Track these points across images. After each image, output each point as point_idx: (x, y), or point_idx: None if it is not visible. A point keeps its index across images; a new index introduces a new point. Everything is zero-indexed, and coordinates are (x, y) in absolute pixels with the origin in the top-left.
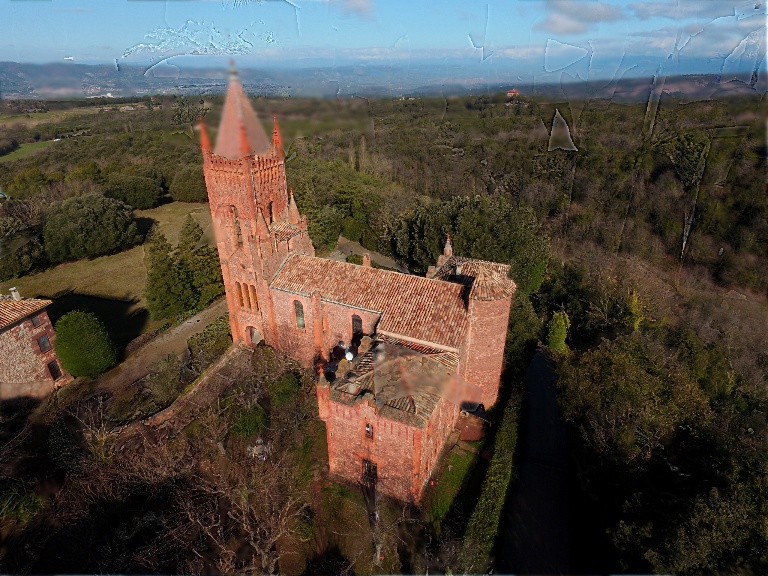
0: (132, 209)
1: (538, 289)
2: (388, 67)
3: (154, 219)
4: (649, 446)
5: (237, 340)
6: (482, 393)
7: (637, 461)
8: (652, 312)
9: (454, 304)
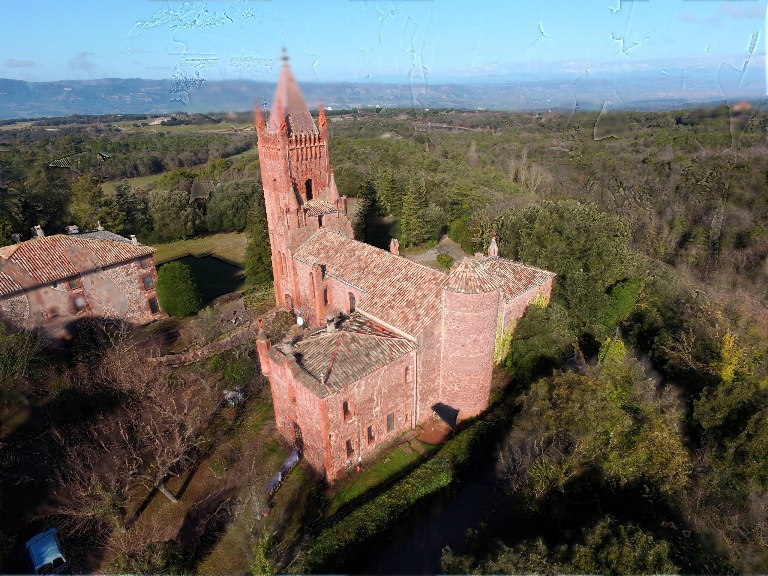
0: None
1: (626, 316)
2: (518, 66)
3: None
4: (543, 482)
5: (278, 306)
6: (459, 398)
7: (524, 495)
8: (764, 366)
9: (433, 293)
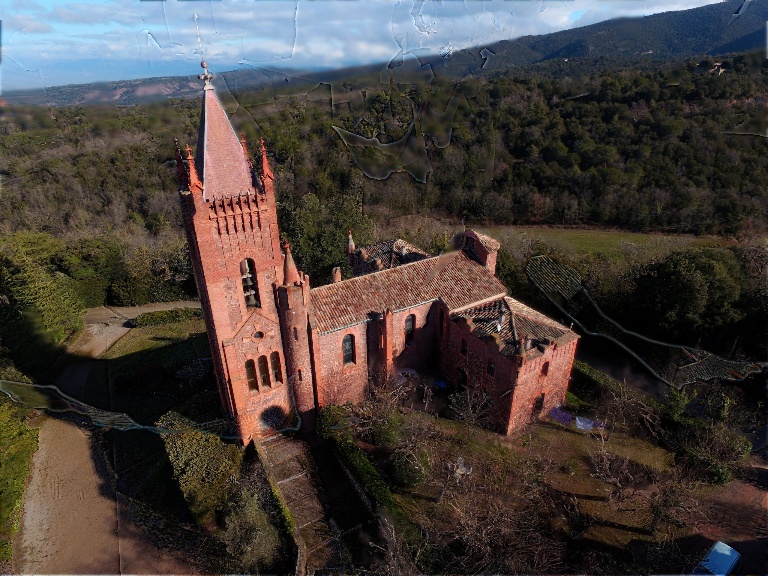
0: None
1: None
2: (36, 72)
3: None
4: None
5: None
6: None
7: None
8: None
9: (471, 266)
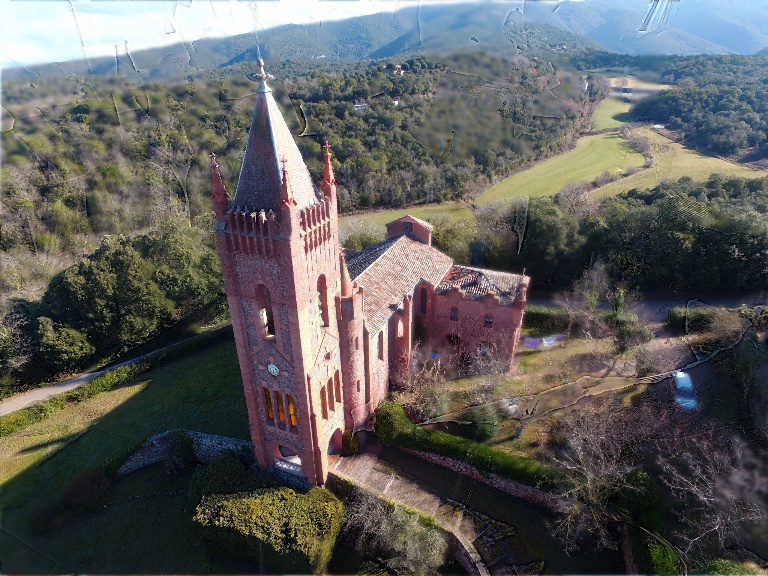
0: None
1: None
2: None
3: None
4: None
5: (329, 471)
6: None
7: None
8: None
9: (419, 246)
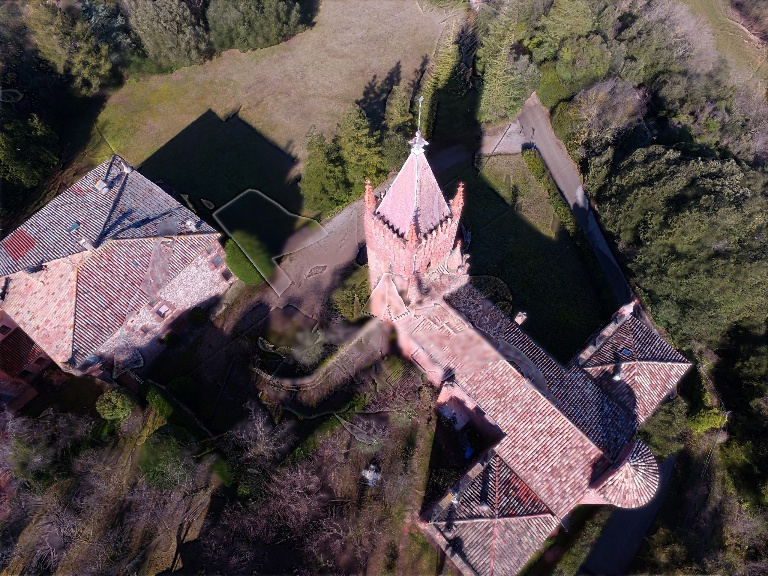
0: None
1: None
2: None
3: None
4: None
5: None
6: None
7: None
8: None
9: (580, 469)
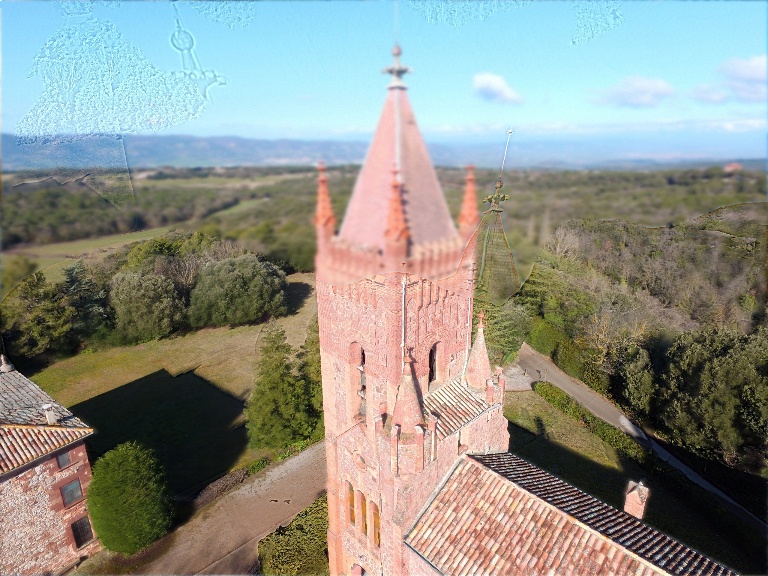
0: (285, 276)
1: None
2: None
3: (310, 285)
4: None
5: None
6: None
7: None
8: None
9: None
